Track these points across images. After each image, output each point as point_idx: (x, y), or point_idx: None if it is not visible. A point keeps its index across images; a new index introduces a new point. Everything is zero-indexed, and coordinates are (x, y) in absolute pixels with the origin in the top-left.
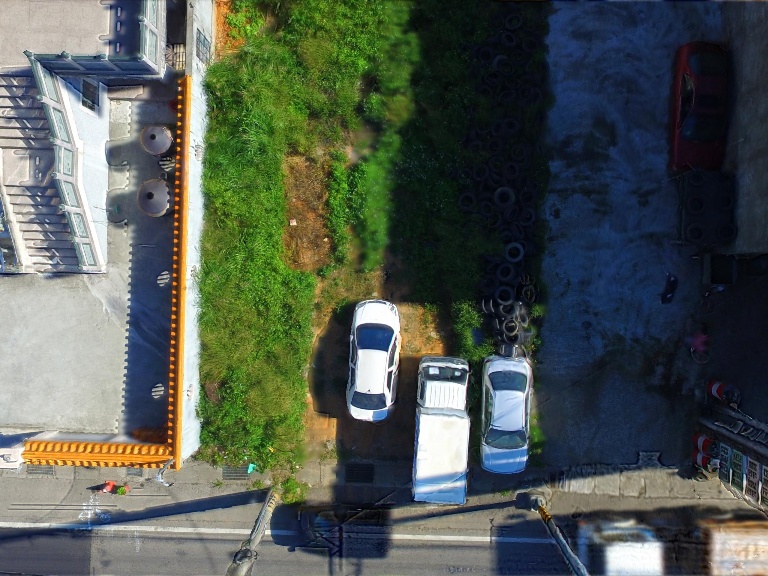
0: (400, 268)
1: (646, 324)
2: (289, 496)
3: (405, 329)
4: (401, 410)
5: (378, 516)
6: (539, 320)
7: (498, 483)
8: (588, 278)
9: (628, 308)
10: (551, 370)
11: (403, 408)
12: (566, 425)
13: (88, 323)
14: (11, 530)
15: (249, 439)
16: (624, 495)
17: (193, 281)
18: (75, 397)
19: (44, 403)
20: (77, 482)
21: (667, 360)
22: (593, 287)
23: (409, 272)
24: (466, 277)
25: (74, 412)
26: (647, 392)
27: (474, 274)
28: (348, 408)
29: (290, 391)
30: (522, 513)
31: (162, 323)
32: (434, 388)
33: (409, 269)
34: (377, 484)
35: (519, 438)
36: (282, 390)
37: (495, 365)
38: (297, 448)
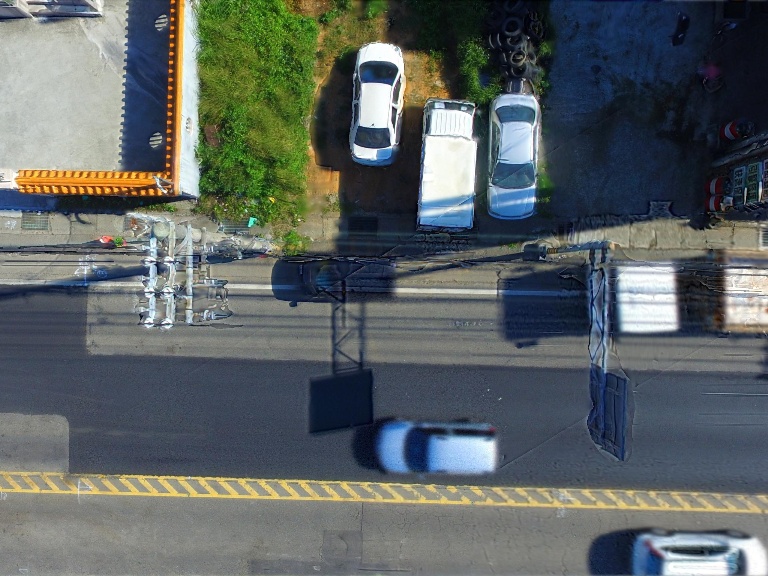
0: (404, 15)
1: (657, 68)
2: (291, 248)
3: (409, 78)
4: (405, 161)
5: (382, 270)
6: (547, 61)
7: (505, 235)
8: (597, 20)
9: (638, 51)
10: (559, 117)
11: (407, 159)
12: (575, 174)
13: (84, 69)
14: (5, 287)
15: (249, 184)
16: (634, 247)
17: (192, 10)
18: (71, 147)
19: (39, 153)
20: (73, 237)
21: (678, 105)
22: (602, 30)
23: (413, 19)
24: (472, 13)
25: (70, 162)
26: (658, 138)
27: (481, 7)
28: (351, 149)
29: (292, 137)
30: (530, 265)
31: (160, 69)
32: (440, 116)
33: (413, 15)
34: (381, 237)
35: (527, 177)
36: (283, 133)
37: (502, 99)
38: (299, 200)
